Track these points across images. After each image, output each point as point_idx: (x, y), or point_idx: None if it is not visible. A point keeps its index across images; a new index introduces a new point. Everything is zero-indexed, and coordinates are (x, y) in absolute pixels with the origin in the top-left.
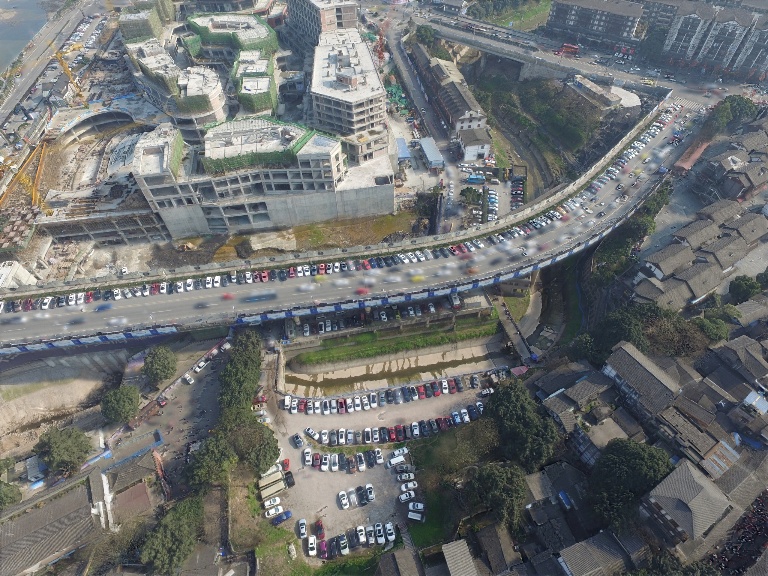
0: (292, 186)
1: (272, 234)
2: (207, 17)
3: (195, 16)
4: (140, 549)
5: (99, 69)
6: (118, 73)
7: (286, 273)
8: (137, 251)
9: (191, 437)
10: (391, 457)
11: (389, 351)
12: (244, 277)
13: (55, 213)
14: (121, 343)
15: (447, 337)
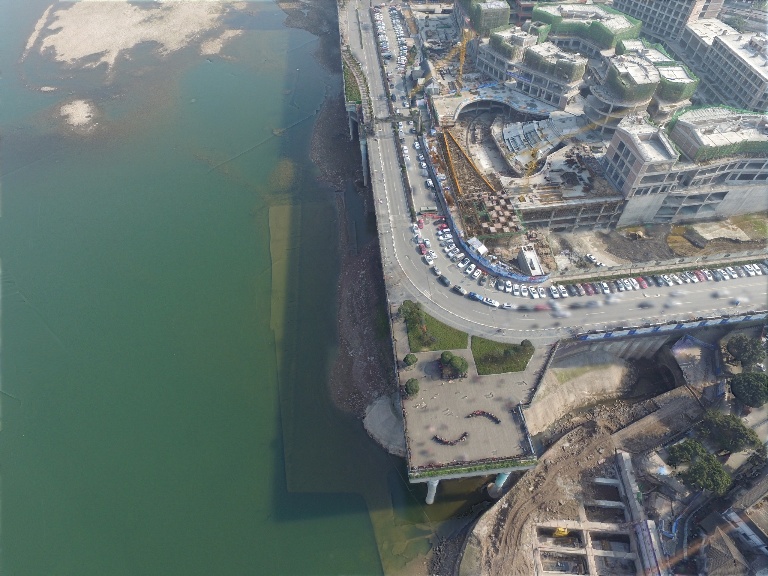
0: (756, 176)
1: (713, 224)
2: (550, 7)
3: (537, 5)
4: None
5: (436, 58)
6: (457, 62)
7: None
8: (586, 239)
9: None
10: None
11: None
12: None
13: (527, 199)
14: None
15: None
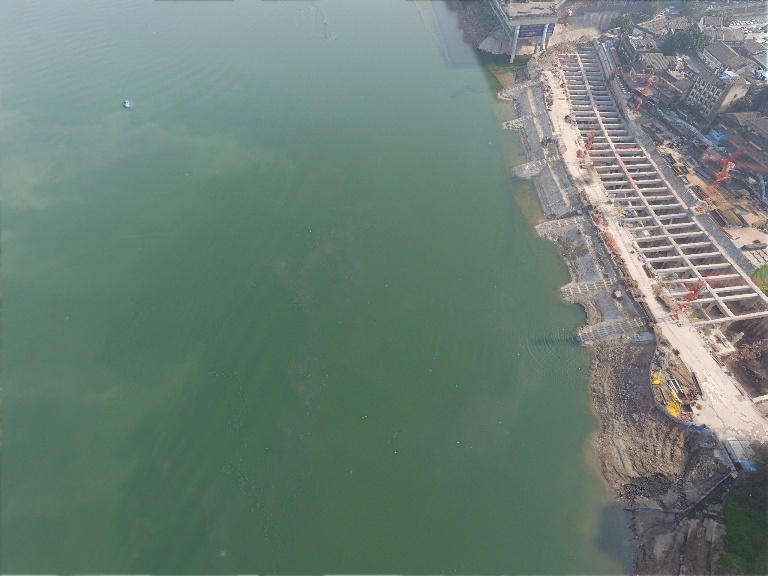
0: None
1: None
2: None
3: None
4: None
5: None
6: None
7: None
8: None
9: None
10: None
11: None
12: None
13: None
14: (622, 6)
15: (765, 16)
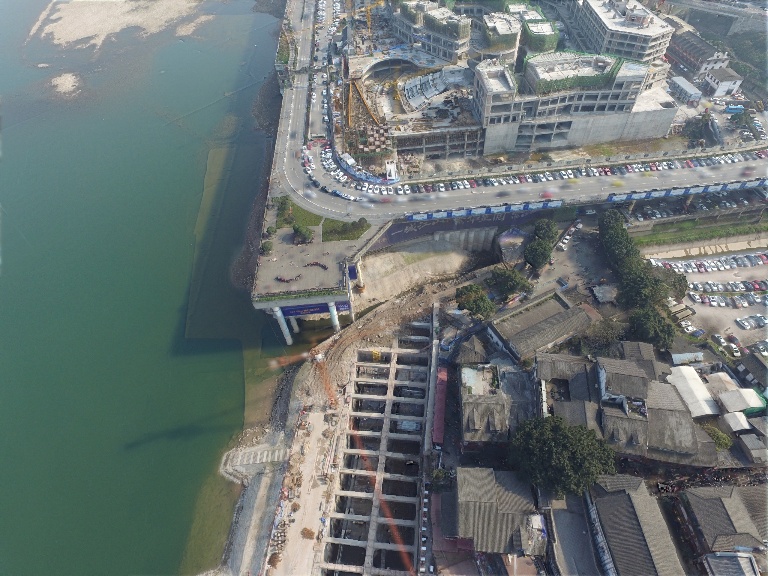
0: None
1: (566, 152)
2: None
3: None
4: (646, 327)
5: (361, 27)
6: (378, 30)
7: (624, 169)
8: (456, 164)
9: (588, 284)
10: (765, 299)
11: (706, 237)
12: (592, 171)
13: (402, 129)
14: (498, 220)
15: (754, 227)
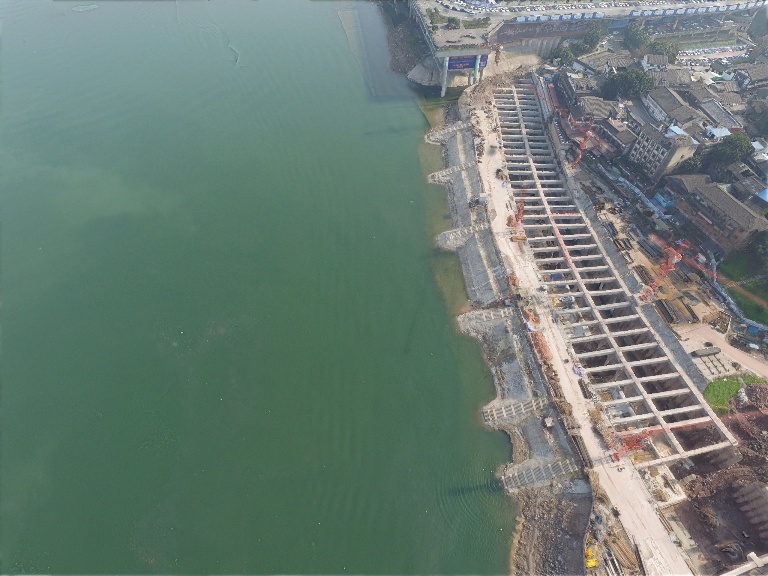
0: None
1: None
2: None
3: None
4: (661, 52)
5: None
6: None
7: (637, 3)
8: None
9: None
10: None
11: (685, 49)
12: (618, 4)
13: None
14: (563, 31)
15: (713, 44)
